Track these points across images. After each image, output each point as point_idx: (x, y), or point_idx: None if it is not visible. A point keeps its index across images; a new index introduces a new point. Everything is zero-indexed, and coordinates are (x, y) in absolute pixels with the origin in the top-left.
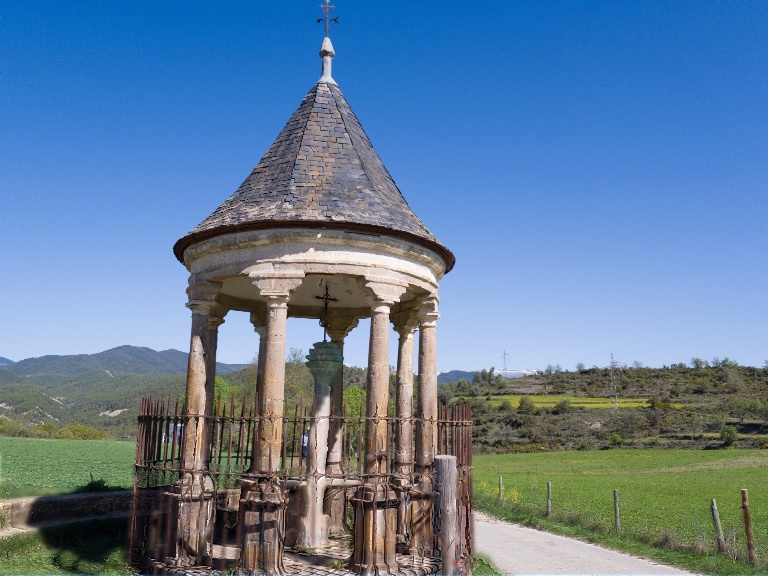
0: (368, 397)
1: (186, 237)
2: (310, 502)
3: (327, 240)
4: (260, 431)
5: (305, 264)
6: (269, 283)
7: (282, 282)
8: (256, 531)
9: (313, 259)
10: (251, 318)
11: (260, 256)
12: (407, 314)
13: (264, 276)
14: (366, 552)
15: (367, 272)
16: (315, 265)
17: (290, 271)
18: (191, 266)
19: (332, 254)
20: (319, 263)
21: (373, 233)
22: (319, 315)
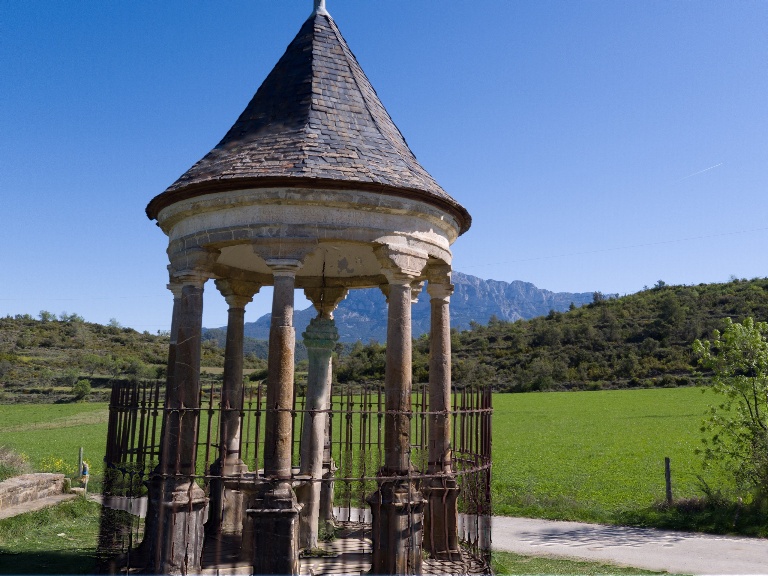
0: (439, 386)
1: (302, 177)
2: (315, 498)
3: (442, 223)
4: (398, 425)
5: (430, 245)
6: (406, 260)
7: (415, 261)
8: (408, 536)
9: (435, 241)
10: (174, 270)
11: (393, 226)
12: (339, 291)
13: (403, 251)
14: (452, 538)
15: (449, 261)
16: (435, 248)
17: (421, 250)
18: (257, 208)
19: (440, 238)
20: (438, 246)
21: (460, 223)
22: (226, 276)
